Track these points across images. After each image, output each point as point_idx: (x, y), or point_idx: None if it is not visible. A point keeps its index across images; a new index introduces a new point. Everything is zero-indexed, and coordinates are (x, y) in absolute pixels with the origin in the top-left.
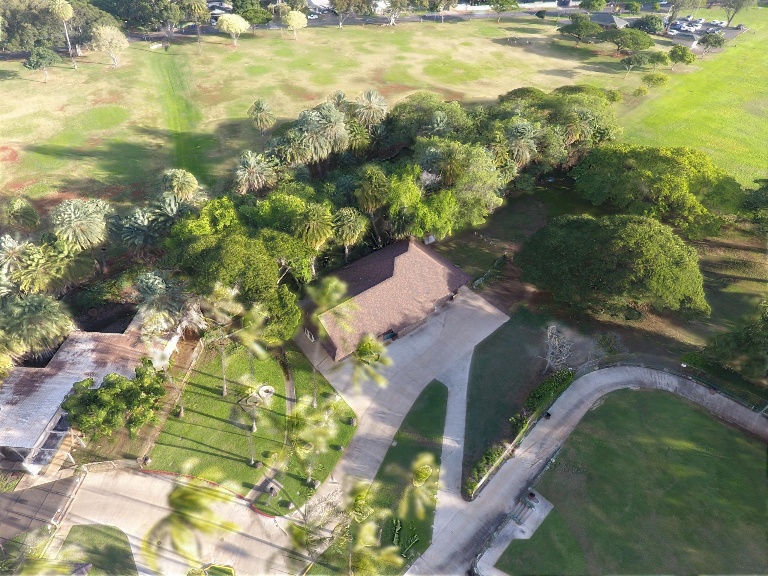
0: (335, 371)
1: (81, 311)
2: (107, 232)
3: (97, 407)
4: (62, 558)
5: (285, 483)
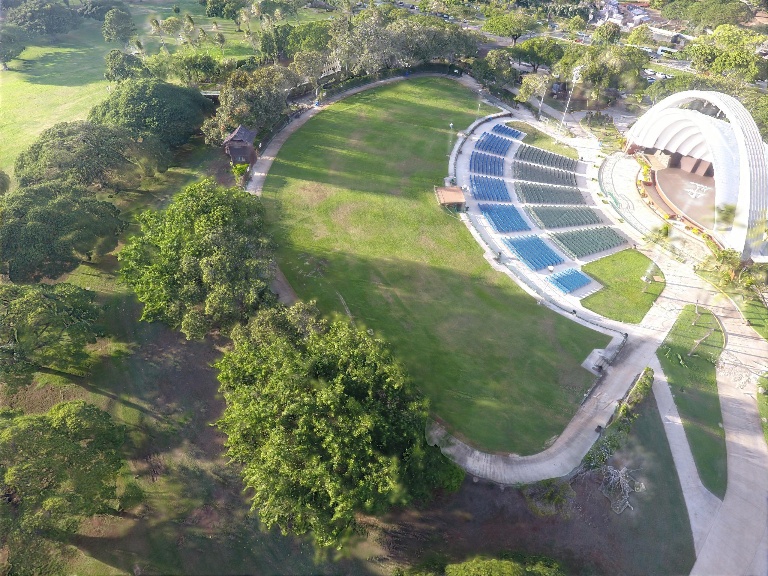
0: None
1: None
2: None
3: None
4: None
5: None
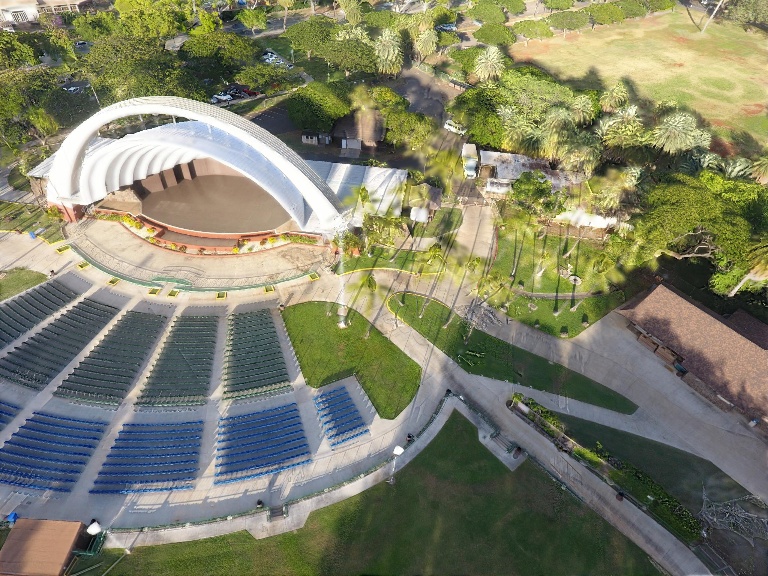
0: (614, 324)
1: (608, 180)
2: (681, 153)
3: (526, 182)
4: (445, 209)
5: (502, 293)
